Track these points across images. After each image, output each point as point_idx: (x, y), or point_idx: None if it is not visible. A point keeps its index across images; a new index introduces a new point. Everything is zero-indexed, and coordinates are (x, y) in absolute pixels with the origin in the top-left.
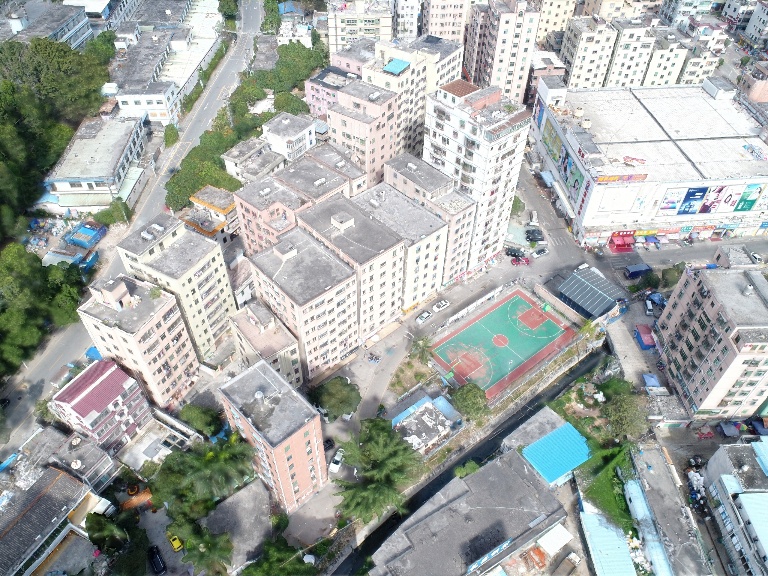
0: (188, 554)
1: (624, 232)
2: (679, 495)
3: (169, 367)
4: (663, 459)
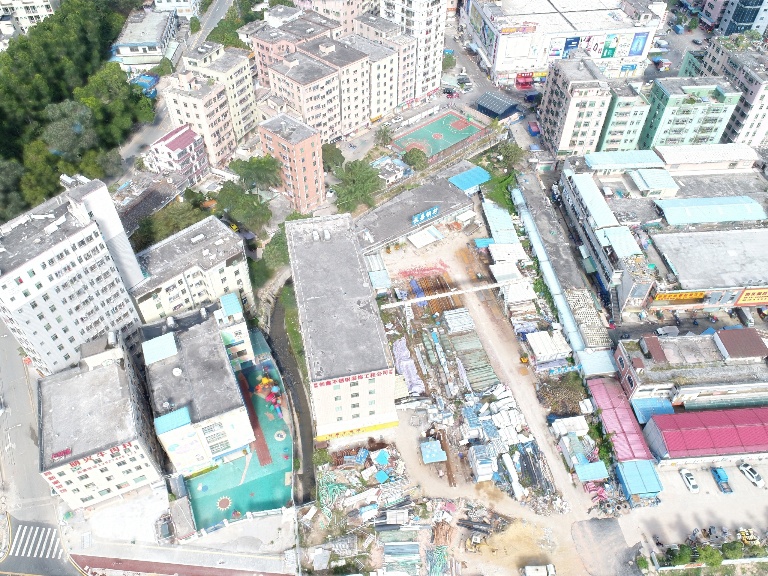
0: (246, 212)
1: (525, 74)
2: (543, 191)
3: (220, 135)
4: (535, 177)
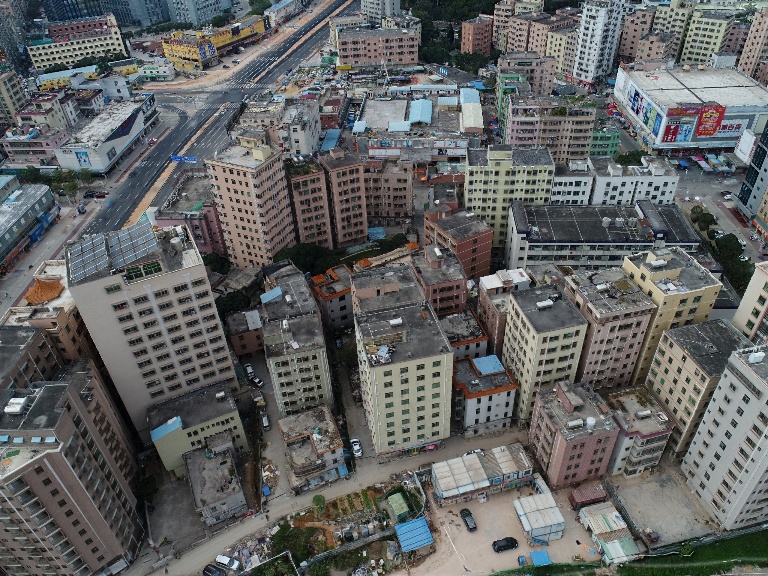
0: None
1: None
2: None
3: None
4: None
